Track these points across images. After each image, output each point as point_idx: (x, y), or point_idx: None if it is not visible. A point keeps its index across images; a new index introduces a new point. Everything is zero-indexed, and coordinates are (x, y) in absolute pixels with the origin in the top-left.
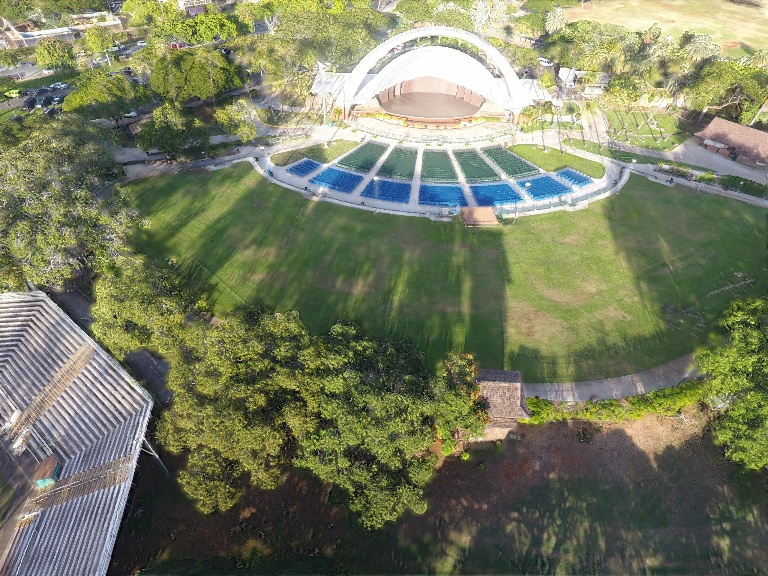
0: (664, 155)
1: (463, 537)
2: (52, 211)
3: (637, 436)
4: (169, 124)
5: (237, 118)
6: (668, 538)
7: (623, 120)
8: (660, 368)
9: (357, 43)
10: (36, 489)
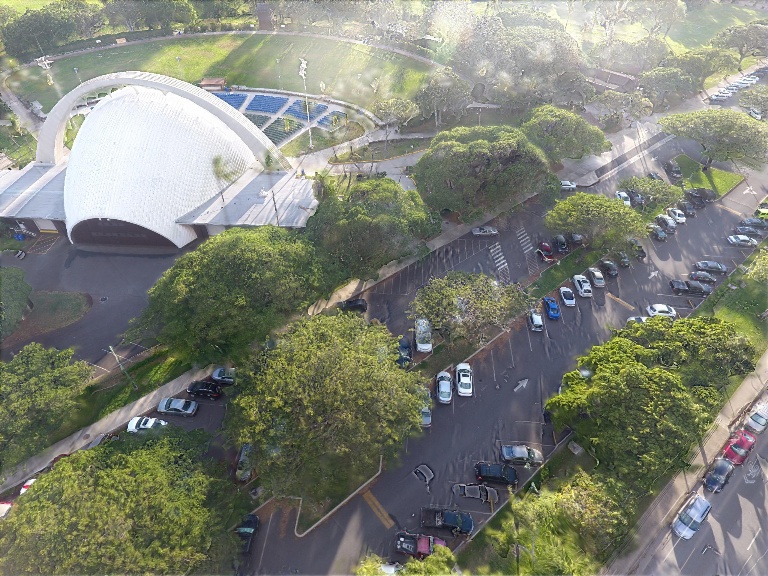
0: None
1: None
2: None
3: None
4: None
5: None
6: None
7: None
8: (191, 36)
9: None
10: None
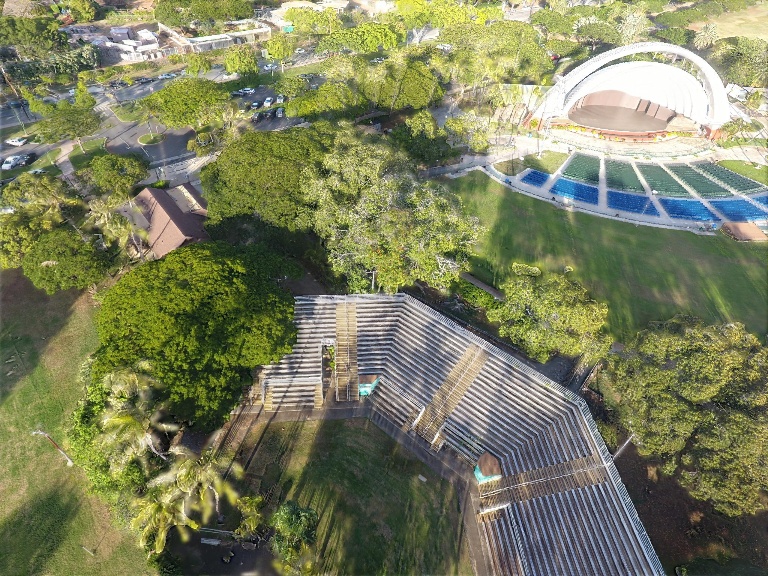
0: None
1: None
2: (434, 217)
3: None
4: (424, 133)
5: (471, 128)
6: None
7: None
8: None
9: (534, 56)
10: (473, 484)
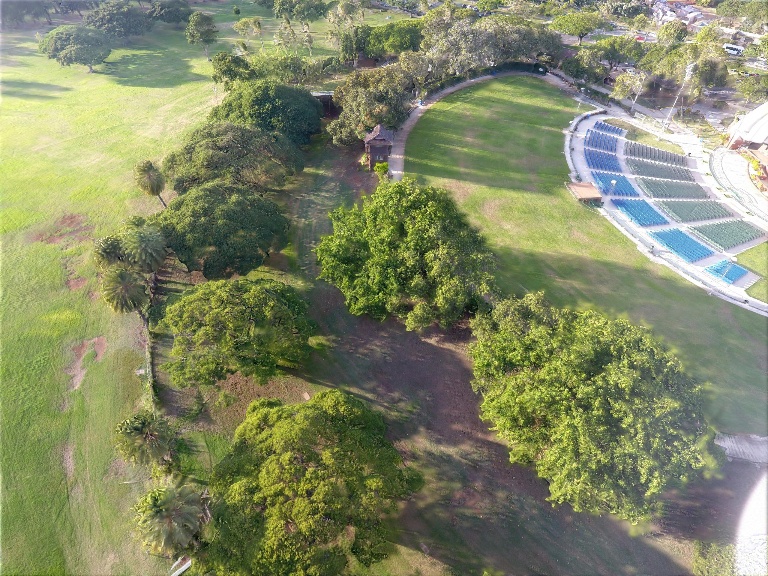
0: None
1: (331, 173)
2: None
3: None
4: (581, 59)
5: (624, 81)
6: None
7: None
8: None
9: None
10: None
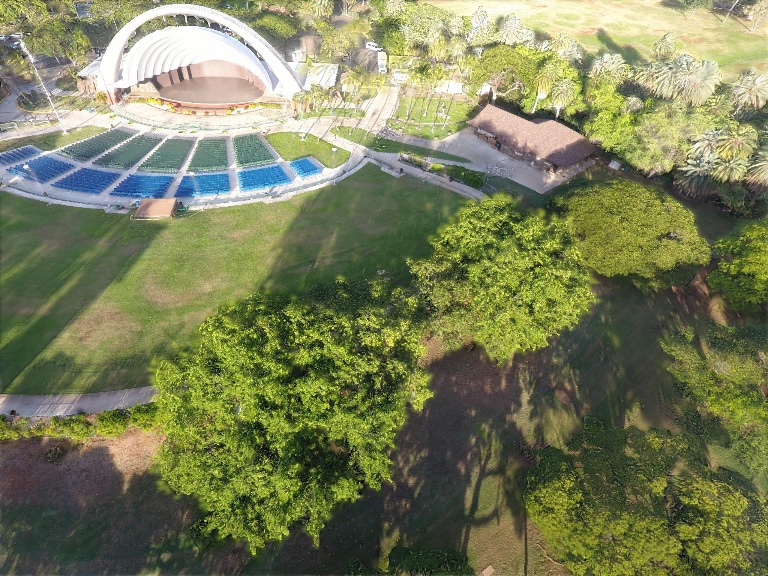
0: (429, 144)
1: None
2: None
3: (120, 454)
4: None
5: None
6: (86, 572)
7: (414, 107)
8: None
9: (150, 24)
10: None
